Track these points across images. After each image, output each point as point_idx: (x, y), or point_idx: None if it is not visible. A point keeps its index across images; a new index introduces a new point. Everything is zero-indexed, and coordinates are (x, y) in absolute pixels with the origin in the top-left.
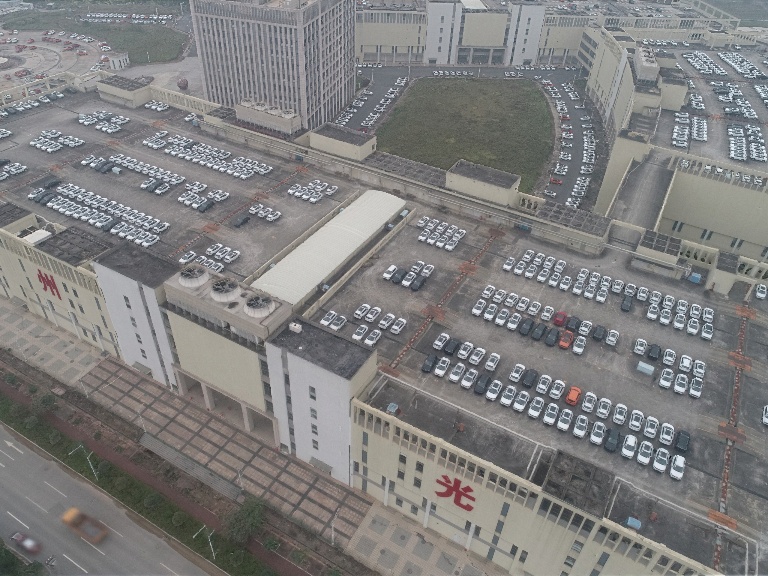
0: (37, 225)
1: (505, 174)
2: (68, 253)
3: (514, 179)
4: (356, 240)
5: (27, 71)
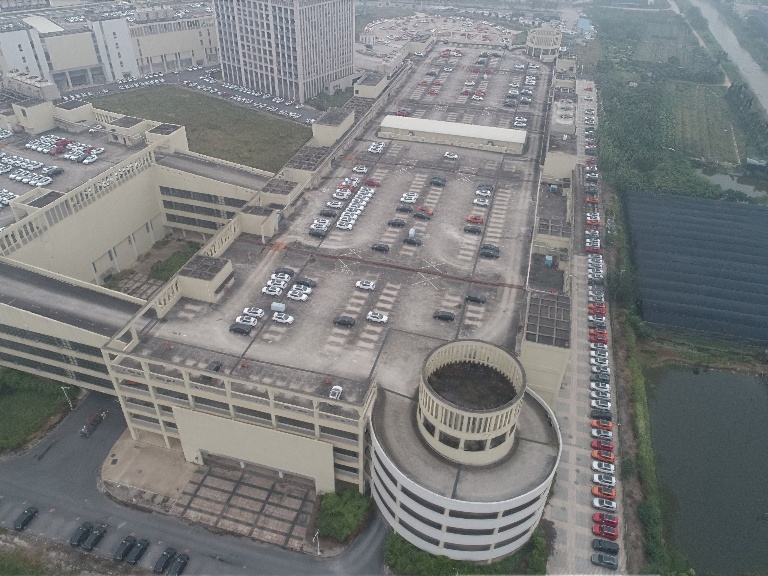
0: (135, 4)
1: (7, 33)
2: (98, 0)
3: (1, 35)
4: (38, 27)
5: None
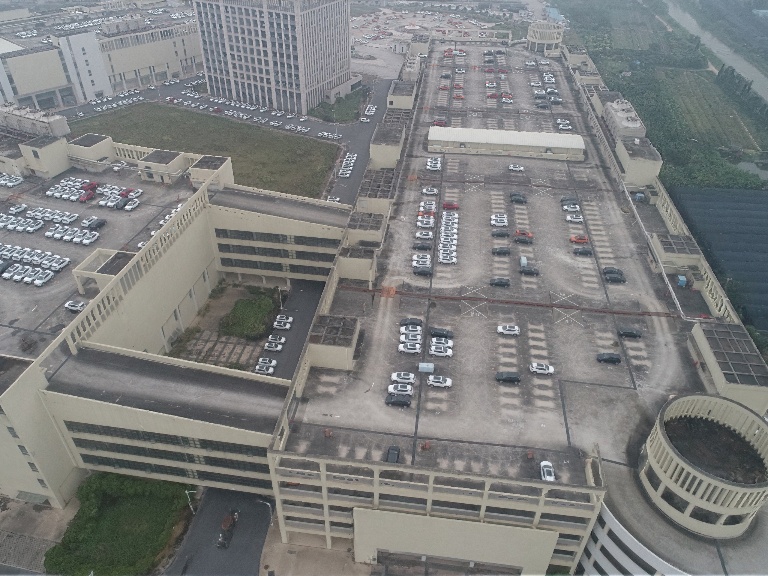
0: (90, 14)
1: None
2: None
3: None
4: None
5: (389, 33)
